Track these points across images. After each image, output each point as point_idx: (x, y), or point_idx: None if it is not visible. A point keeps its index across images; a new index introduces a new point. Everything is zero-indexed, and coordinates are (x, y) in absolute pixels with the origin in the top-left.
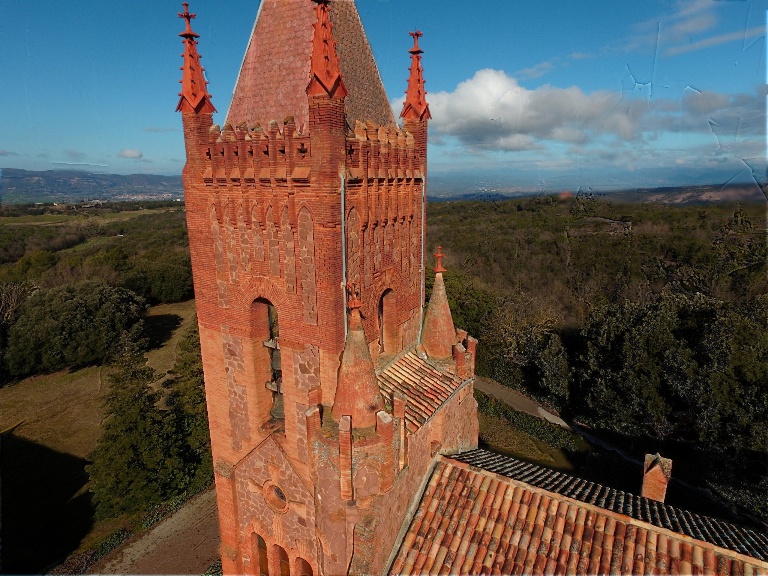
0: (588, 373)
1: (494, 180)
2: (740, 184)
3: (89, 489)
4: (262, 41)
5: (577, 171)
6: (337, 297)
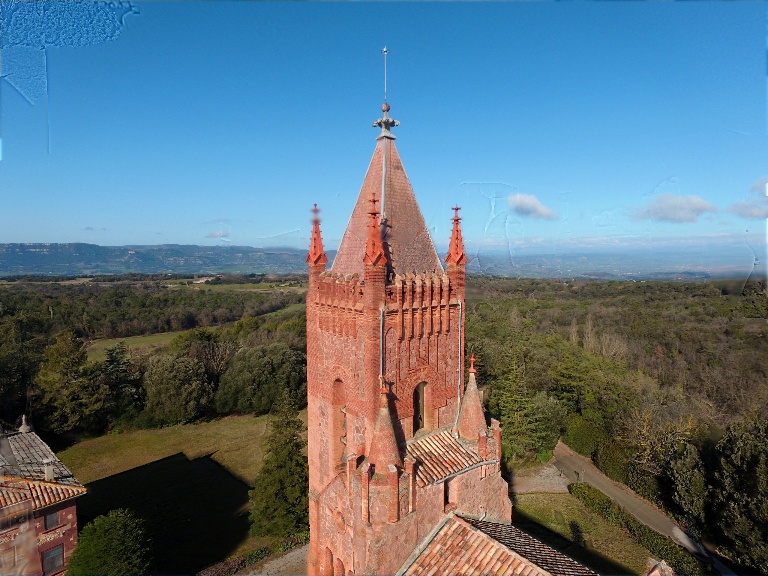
0: (723, 494)
1: (644, 271)
2: None
3: (249, 510)
4: None
5: None
6: (375, 385)
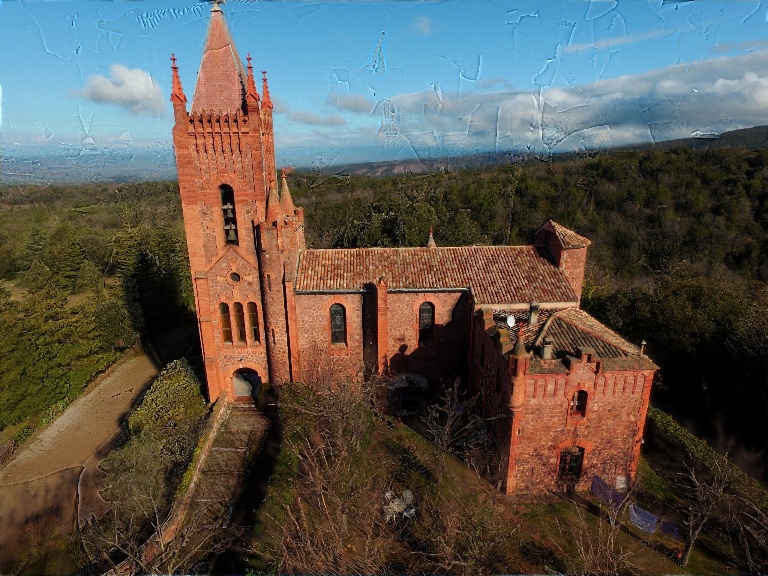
0: None
1: None
2: (407, 151)
3: None
4: (207, 72)
5: (307, 143)
6: None
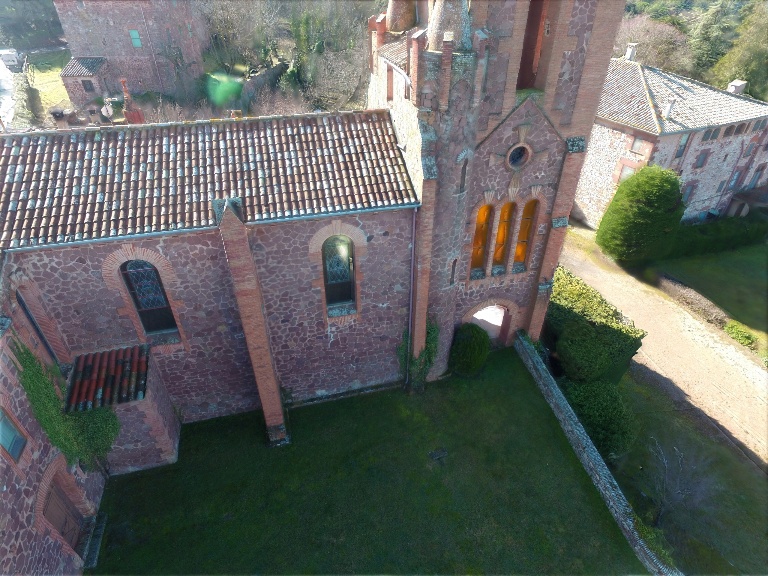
0: None
1: None
2: None
3: None
4: None
5: None
6: None
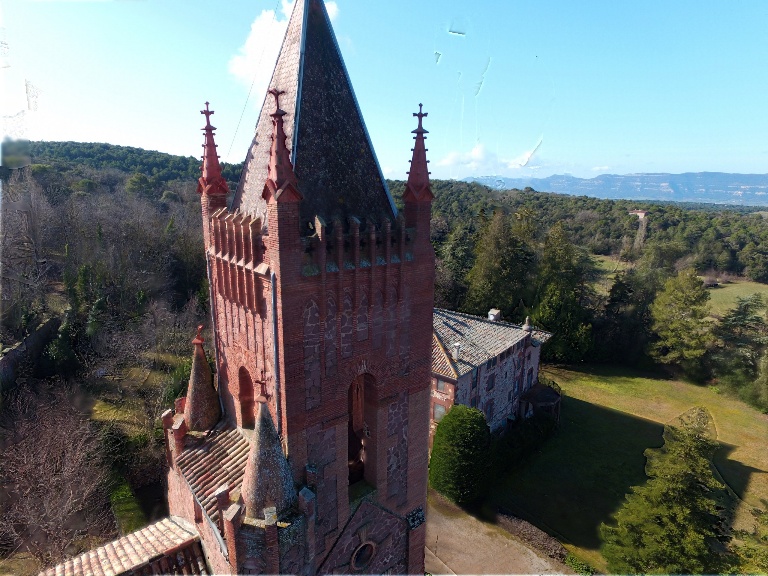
0: None
1: None
2: None
3: None
4: None
5: None
6: None
